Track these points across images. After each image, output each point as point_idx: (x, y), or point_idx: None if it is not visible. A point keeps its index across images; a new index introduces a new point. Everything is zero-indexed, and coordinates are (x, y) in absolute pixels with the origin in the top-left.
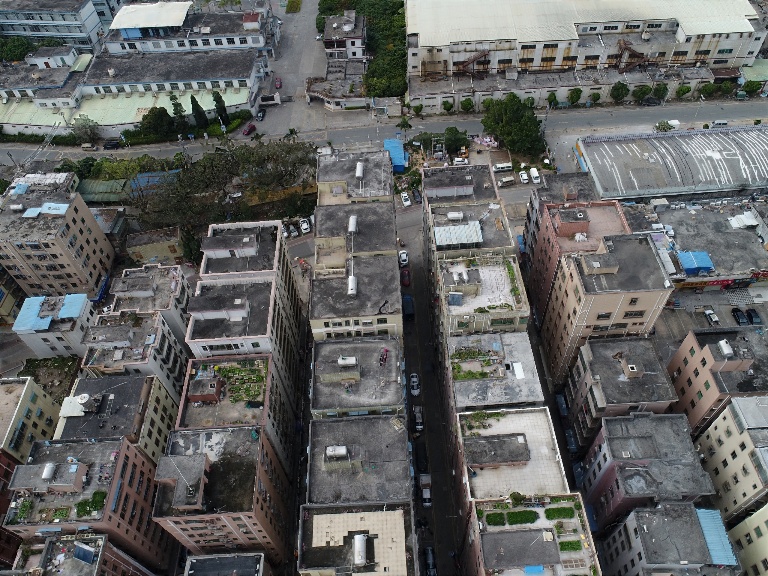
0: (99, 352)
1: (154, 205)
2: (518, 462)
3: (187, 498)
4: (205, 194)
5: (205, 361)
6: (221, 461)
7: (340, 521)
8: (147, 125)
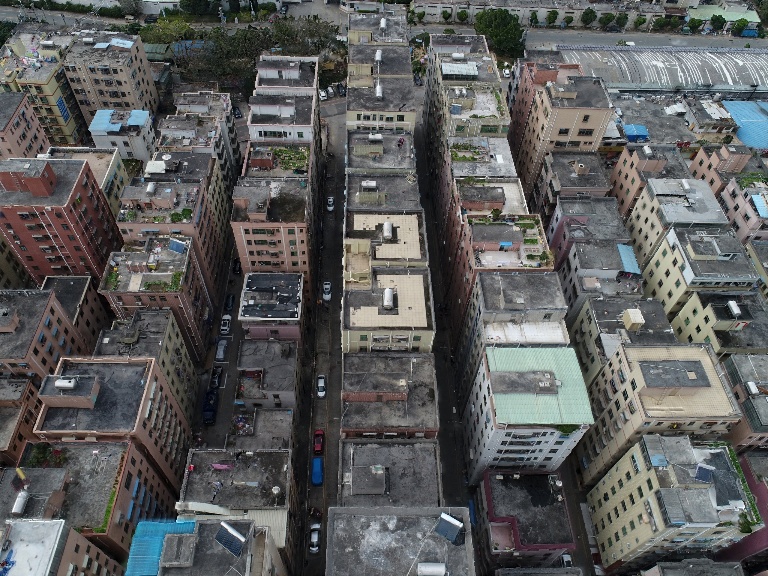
0: (171, 139)
1: (200, 58)
2: (497, 206)
3: (258, 209)
4: (239, 60)
5: (260, 144)
6: (279, 197)
7: (373, 218)
8: (187, 3)
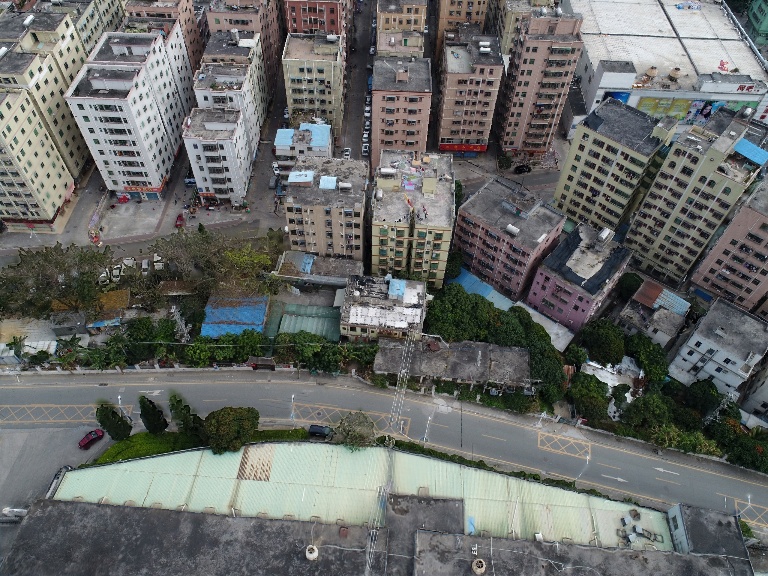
0: None
1: None
2: None
3: None
4: (173, 293)
5: None
6: (153, 2)
7: None
8: (242, 407)
